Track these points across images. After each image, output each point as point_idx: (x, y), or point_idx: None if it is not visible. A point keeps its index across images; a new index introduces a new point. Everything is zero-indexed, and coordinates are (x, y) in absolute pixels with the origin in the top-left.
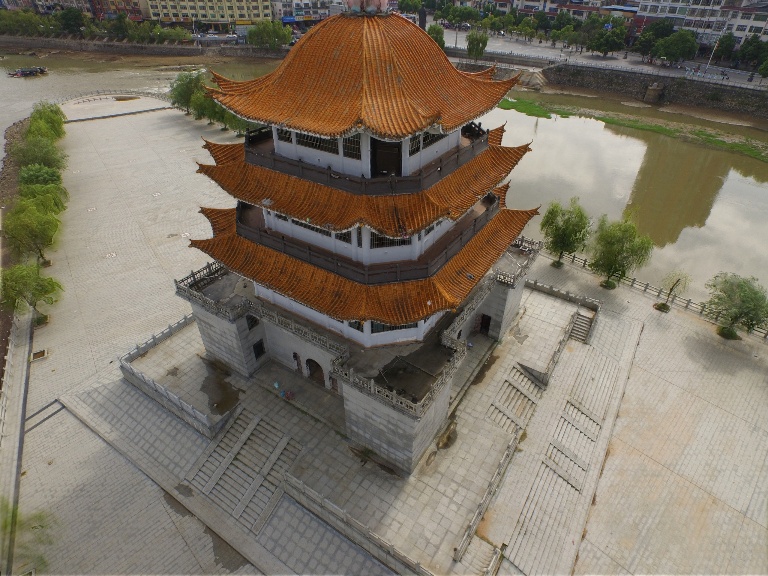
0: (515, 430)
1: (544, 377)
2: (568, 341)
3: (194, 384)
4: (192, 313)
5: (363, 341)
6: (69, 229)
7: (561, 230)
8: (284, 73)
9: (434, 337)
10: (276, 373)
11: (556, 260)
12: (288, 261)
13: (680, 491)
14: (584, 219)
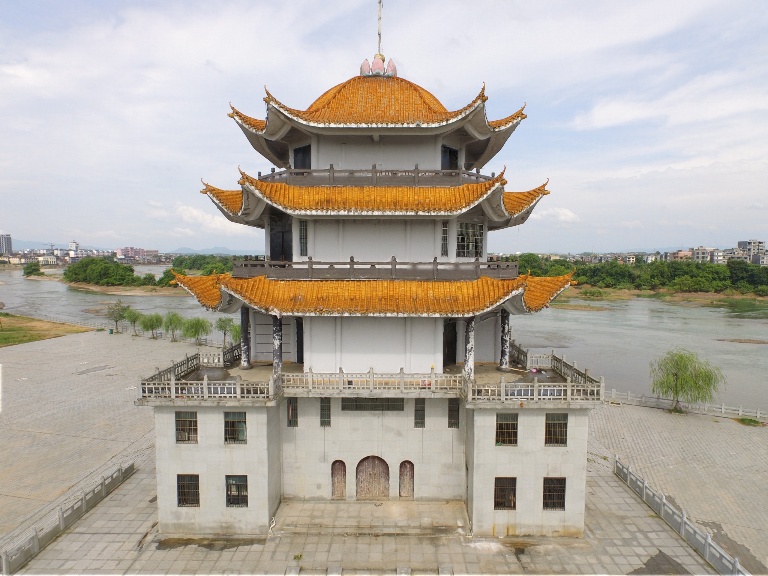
0: None
1: None
2: None
3: None
4: None
5: None
6: None
7: None
8: None
9: None
10: None
11: None
12: None
13: (7, 483)
14: None
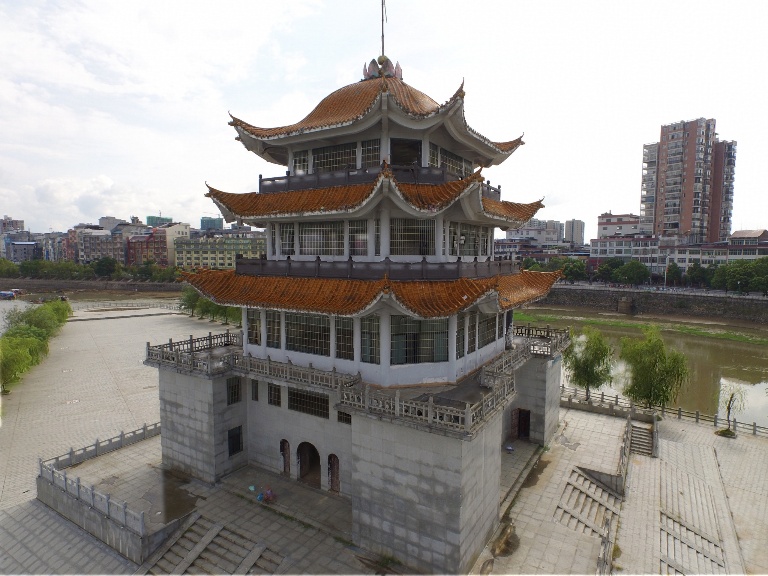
0: None
1: (617, 482)
2: (631, 455)
3: (135, 492)
4: (155, 424)
5: (379, 379)
6: (35, 384)
7: (581, 363)
8: (307, 118)
9: (470, 381)
10: (253, 477)
11: None
12: (292, 283)
13: None
14: (604, 344)
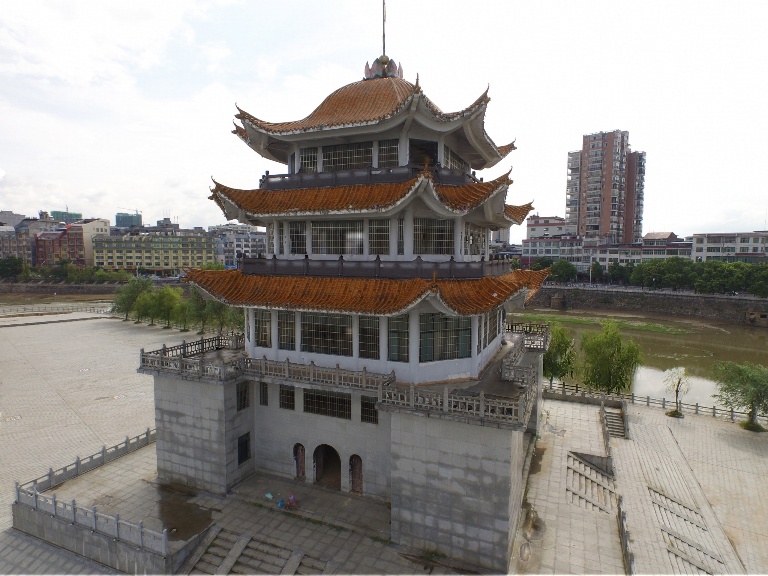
0: None
1: (608, 463)
2: None
3: (138, 510)
4: (137, 437)
5: (408, 377)
6: None
7: (545, 355)
8: (313, 114)
9: (489, 376)
10: (266, 484)
11: None
12: (312, 283)
13: None
14: (566, 338)
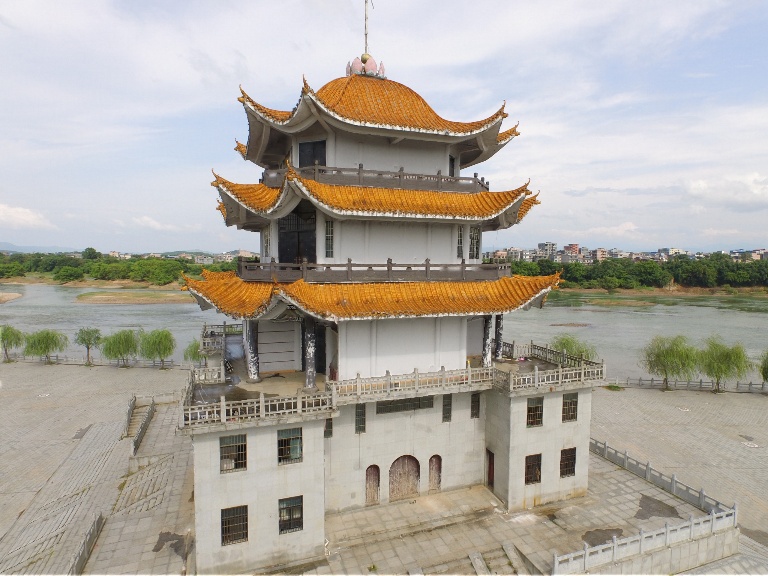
0: None
1: None
2: None
3: None
4: None
5: None
6: (759, 400)
7: None
8: None
9: None
10: None
11: None
12: None
13: None
14: None
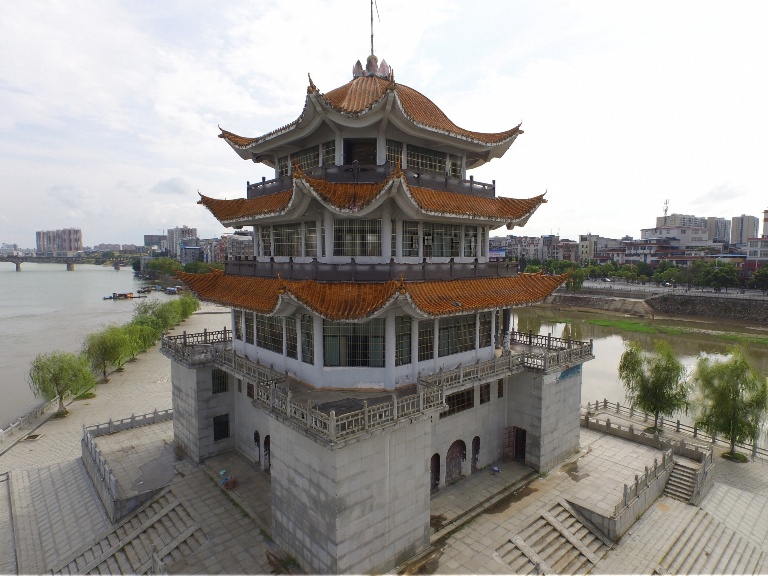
0: (535, 569)
1: (610, 526)
2: (660, 498)
3: (137, 462)
4: None
5: (314, 380)
6: (145, 364)
7: (650, 383)
8: None
9: (410, 390)
10: (231, 462)
11: (652, 427)
12: (254, 283)
13: None
14: (676, 363)
